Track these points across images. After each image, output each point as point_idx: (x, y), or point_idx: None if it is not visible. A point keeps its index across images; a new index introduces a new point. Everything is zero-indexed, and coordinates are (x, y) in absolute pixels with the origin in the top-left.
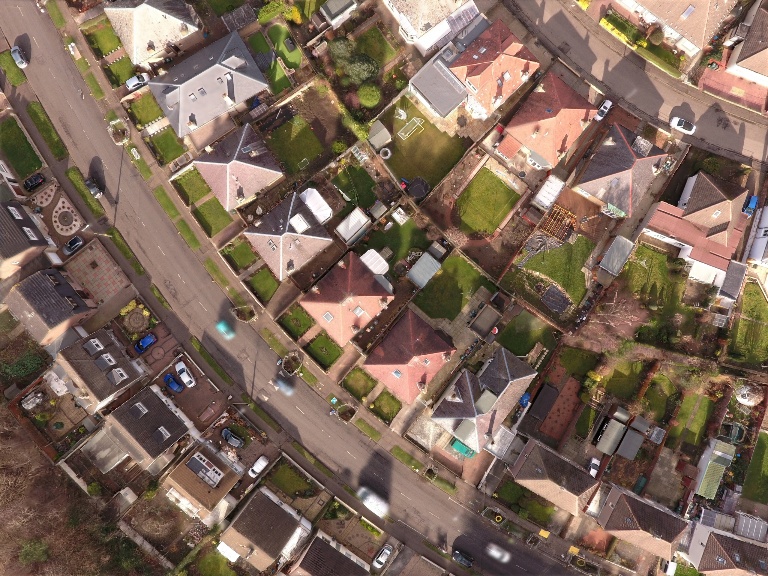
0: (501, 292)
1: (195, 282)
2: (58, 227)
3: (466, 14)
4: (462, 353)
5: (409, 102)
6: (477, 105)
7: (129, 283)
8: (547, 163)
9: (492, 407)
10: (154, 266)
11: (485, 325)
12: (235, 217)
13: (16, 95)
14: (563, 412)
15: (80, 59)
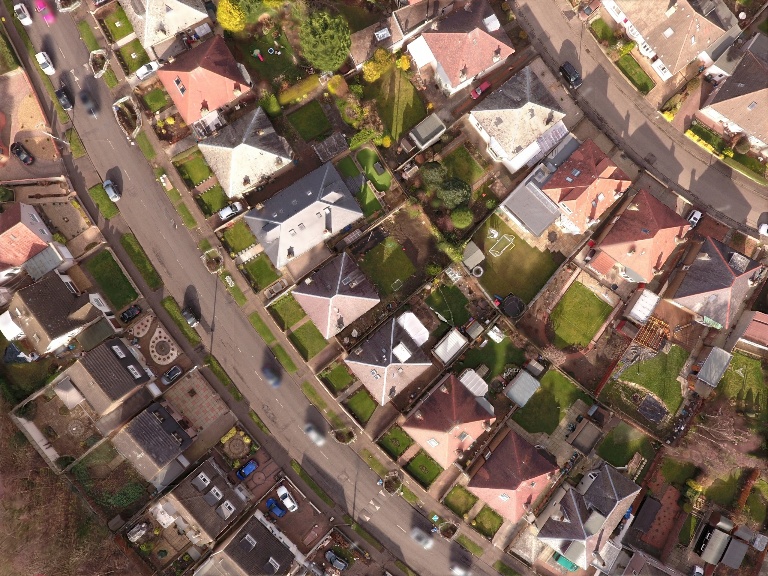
0: (600, 407)
1: (293, 406)
2: (155, 357)
3: (555, 134)
4: (562, 467)
5: (499, 219)
6: (570, 224)
7: (228, 410)
8: (642, 279)
9: (600, 527)
10: (252, 391)
11: (586, 441)
12: (331, 340)
13: (109, 228)
14: (664, 520)
15: (172, 190)
